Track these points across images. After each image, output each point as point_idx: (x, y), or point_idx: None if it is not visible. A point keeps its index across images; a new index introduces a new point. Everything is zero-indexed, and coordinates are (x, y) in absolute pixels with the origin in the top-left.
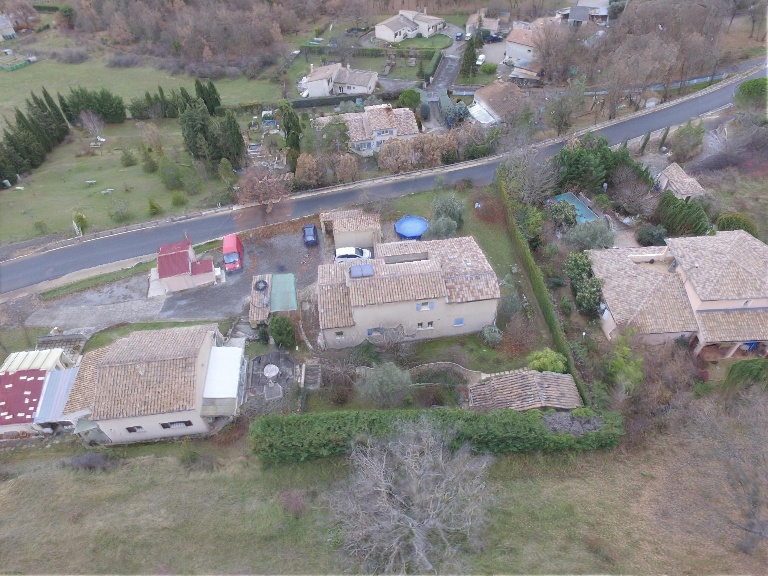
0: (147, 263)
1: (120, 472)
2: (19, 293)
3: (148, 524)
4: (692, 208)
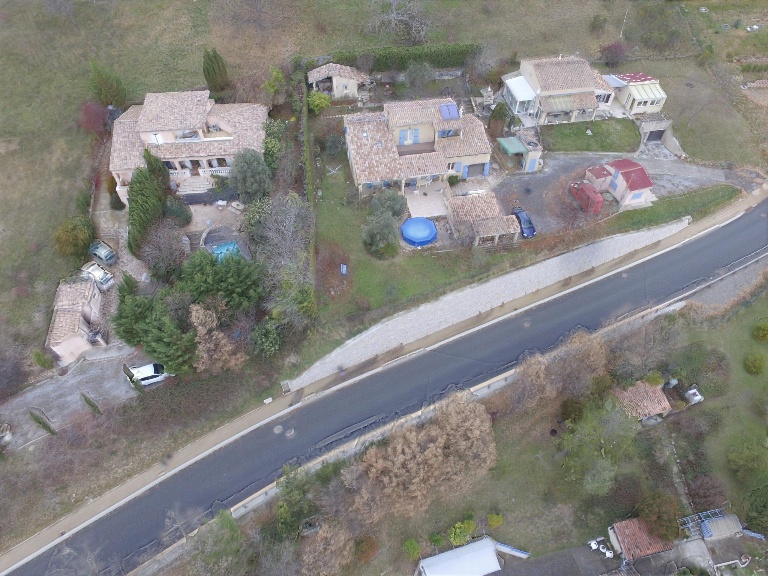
0: (673, 215)
1: (544, 57)
2: (762, 194)
3: (511, 31)
4: (140, 177)
